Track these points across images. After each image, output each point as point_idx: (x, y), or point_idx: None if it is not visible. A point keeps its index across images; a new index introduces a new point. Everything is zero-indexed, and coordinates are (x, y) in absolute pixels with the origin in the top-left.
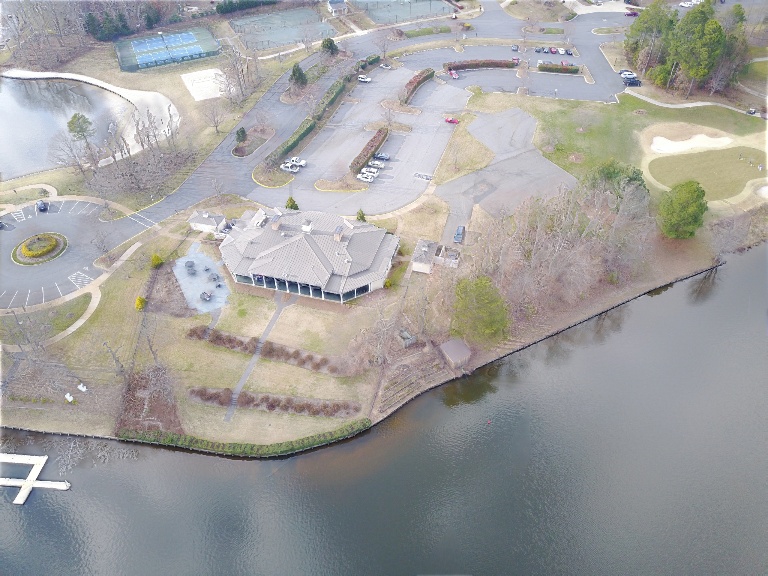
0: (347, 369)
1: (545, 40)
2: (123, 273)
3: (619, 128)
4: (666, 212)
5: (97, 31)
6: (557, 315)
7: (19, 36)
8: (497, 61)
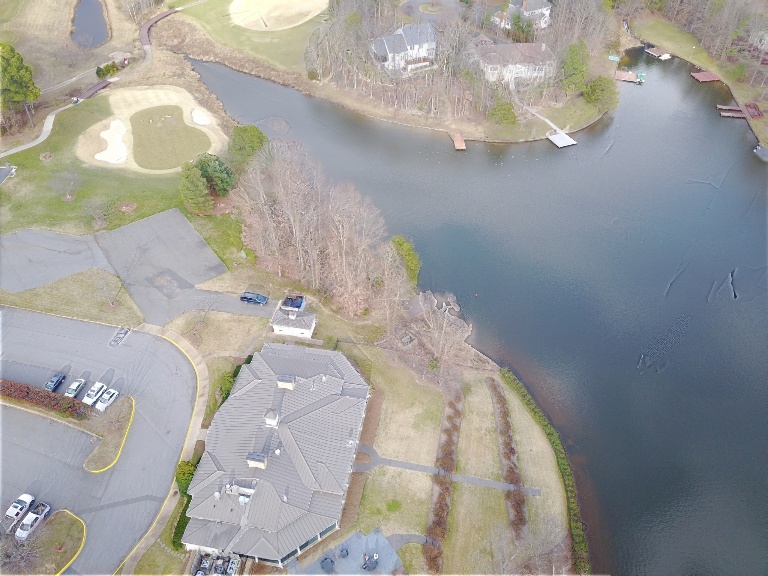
0: (453, 388)
1: None
2: None
3: (74, 174)
4: None
5: None
6: None
7: None
8: None
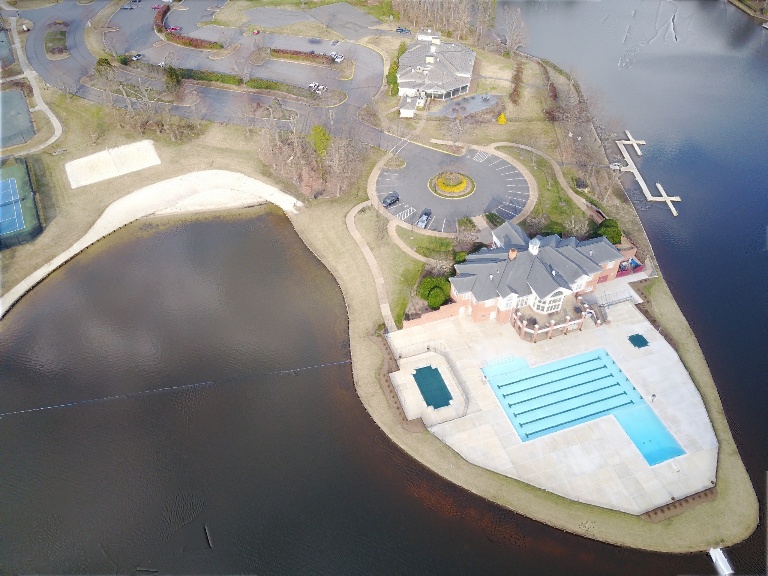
0: None
1: None
2: None
3: None
4: None
5: None
6: None
7: None
8: (163, 10)
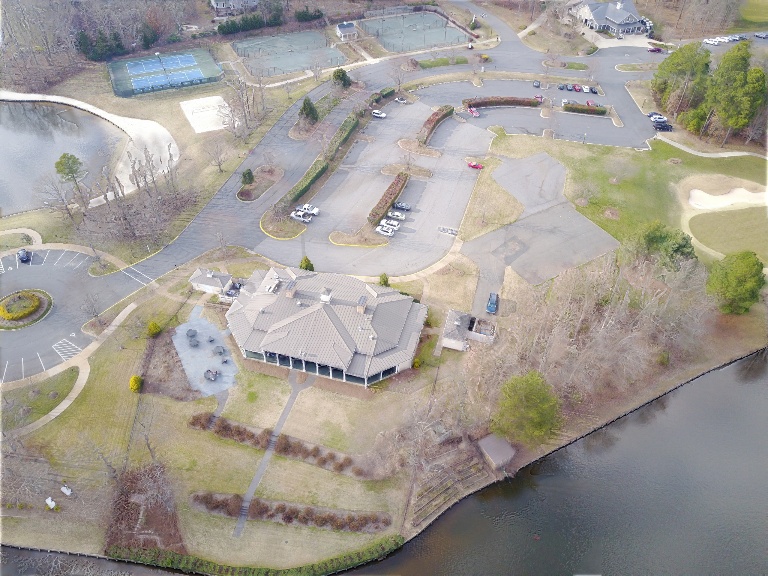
0: (374, 470)
1: (567, 76)
2: (116, 344)
3: (654, 179)
4: (720, 285)
5: (89, 50)
6: (605, 402)
7: (4, 52)
8: (520, 99)
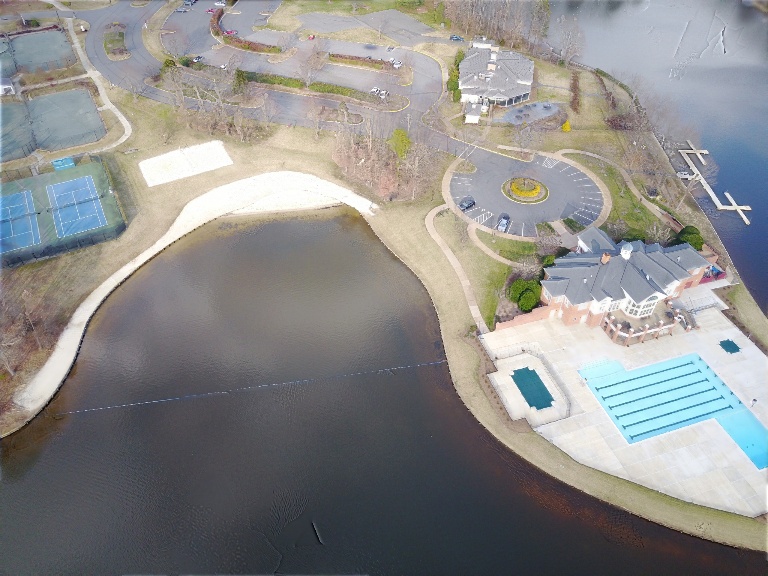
0: None
1: None
2: None
3: None
4: None
5: None
6: None
7: None
8: (217, 13)
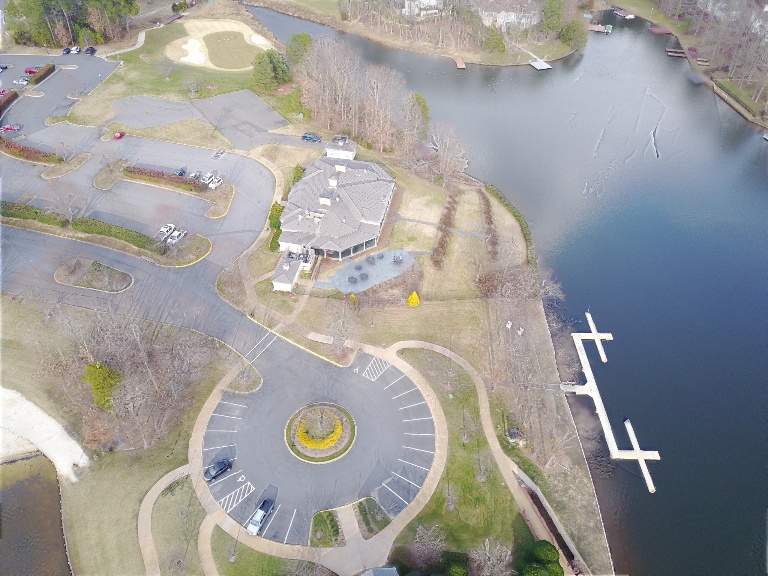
0: None
1: None
2: None
3: (168, 67)
4: None
5: None
6: None
7: None
8: (4, 99)
